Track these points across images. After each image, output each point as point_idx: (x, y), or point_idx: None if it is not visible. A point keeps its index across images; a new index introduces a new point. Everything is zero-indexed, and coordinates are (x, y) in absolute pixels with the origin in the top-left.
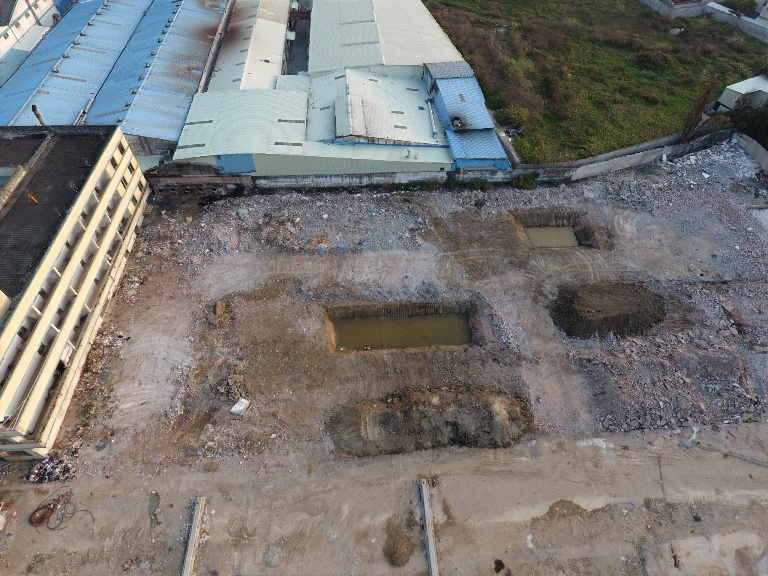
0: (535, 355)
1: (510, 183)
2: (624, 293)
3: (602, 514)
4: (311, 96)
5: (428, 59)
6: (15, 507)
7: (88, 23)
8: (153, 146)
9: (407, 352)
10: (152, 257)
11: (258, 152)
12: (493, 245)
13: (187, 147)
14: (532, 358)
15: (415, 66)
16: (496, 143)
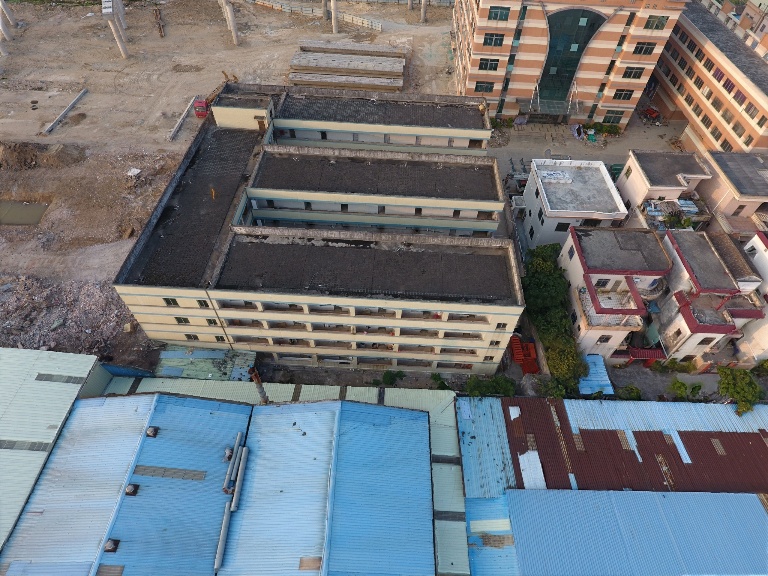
0: None
1: None
2: None
3: None
4: None
5: None
6: None
7: None
8: None
9: None
10: None
11: None
12: None
13: (66, 378)
14: None
15: None
16: None
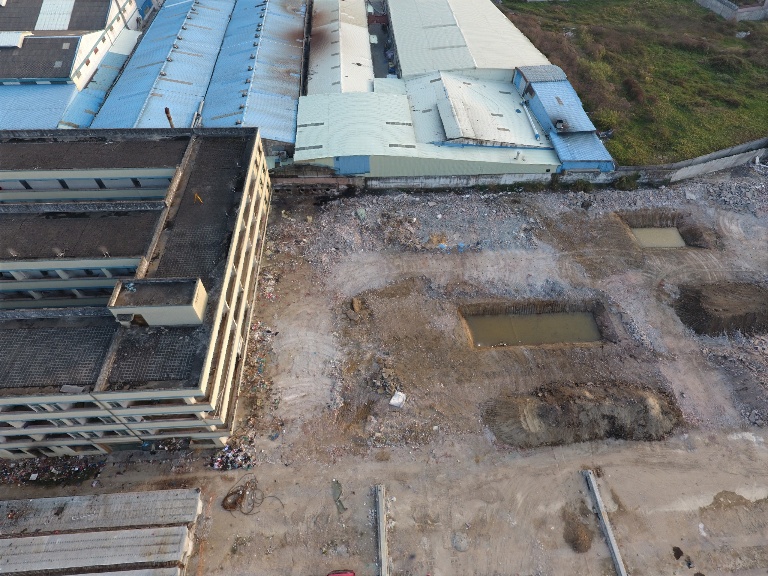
0: (670, 352)
1: (611, 185)
2: (747, 292)
3: (766, 505)
4: (409, 99)
5: (517, 63)
6: (206, 493)
7: (182, 27)
8: (270, 148)
9: (545, 348)
10: (281, 255)
11: (376, 154)
12: (607, 245)
13: (305, 149)
14: (667, 355)
15: (506, 69)
16: (599, 145)
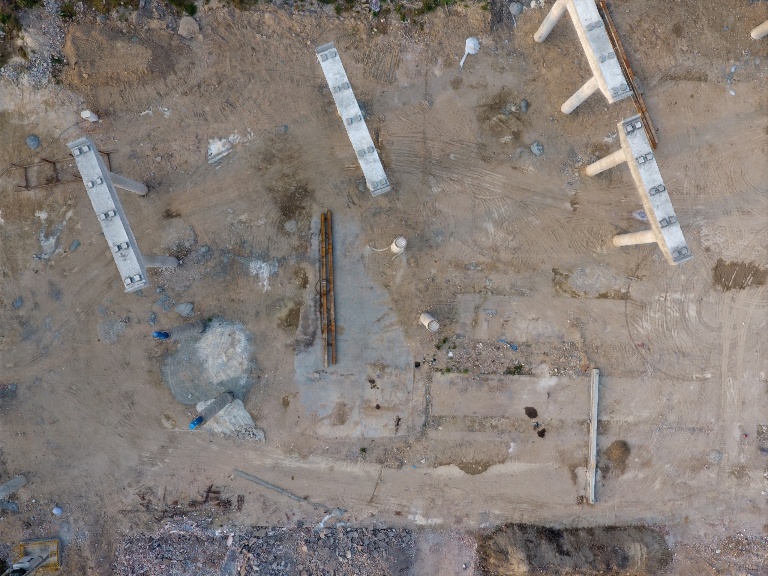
0: None
1: None
2: None
3: (444, 461)
4: None
5: None
6: None
7: None
8: None
9: None
10: None
11: None
12: None
13: None
14: None
15: None
16: None
